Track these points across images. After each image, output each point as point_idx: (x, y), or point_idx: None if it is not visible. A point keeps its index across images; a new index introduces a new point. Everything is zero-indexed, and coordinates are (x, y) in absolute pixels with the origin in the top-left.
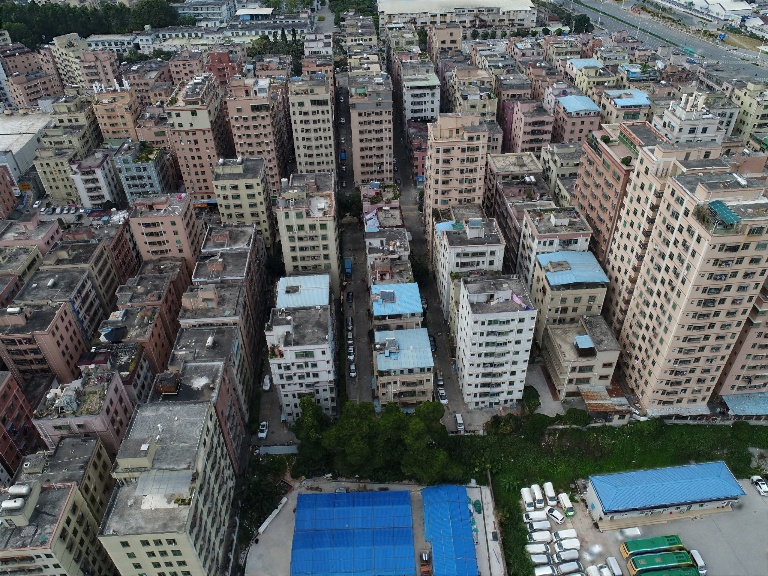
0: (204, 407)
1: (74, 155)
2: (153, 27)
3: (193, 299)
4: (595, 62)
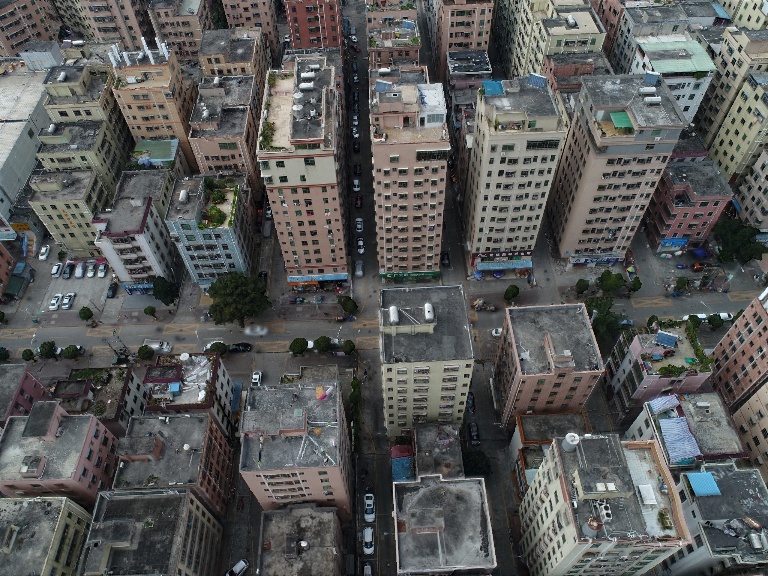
0: None
1: (93, 184)
2: None
3: None
4: None
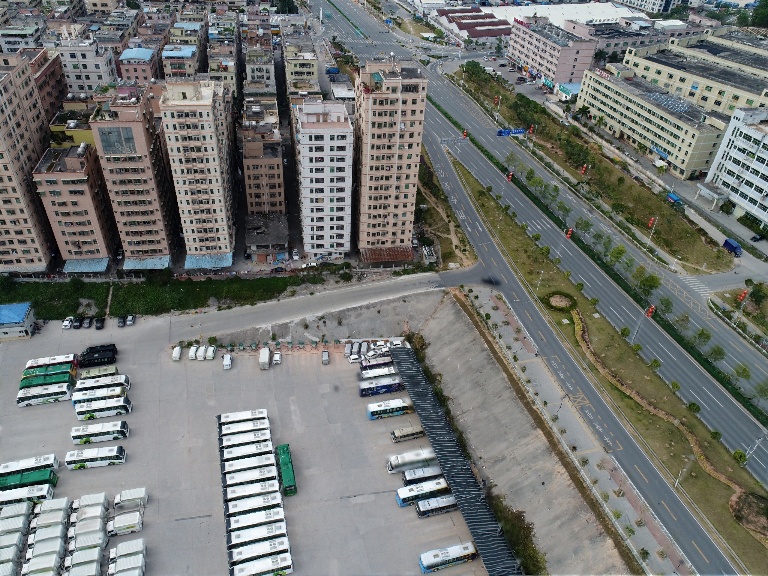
0: None
1: None
2: None
3: None
4: (195, 25)
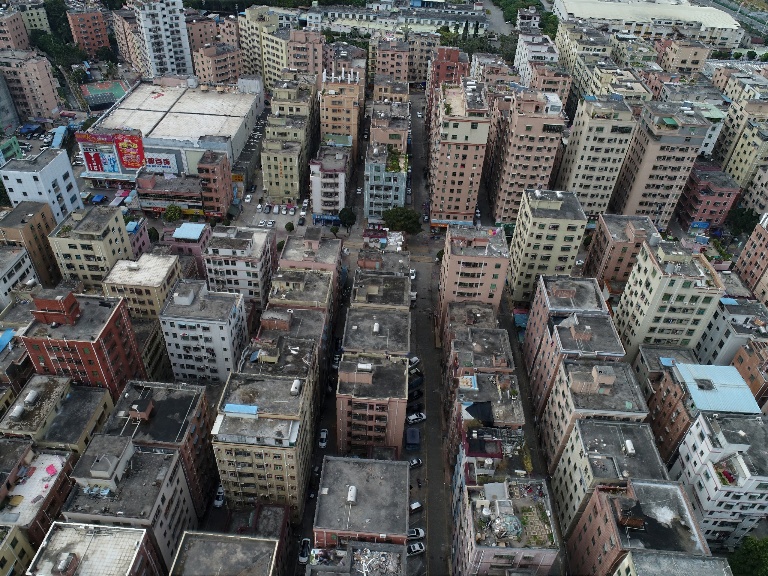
0: (719, 568)
1: (300, 150)
2: (320, 4)
3: (587, 383)
4: None
